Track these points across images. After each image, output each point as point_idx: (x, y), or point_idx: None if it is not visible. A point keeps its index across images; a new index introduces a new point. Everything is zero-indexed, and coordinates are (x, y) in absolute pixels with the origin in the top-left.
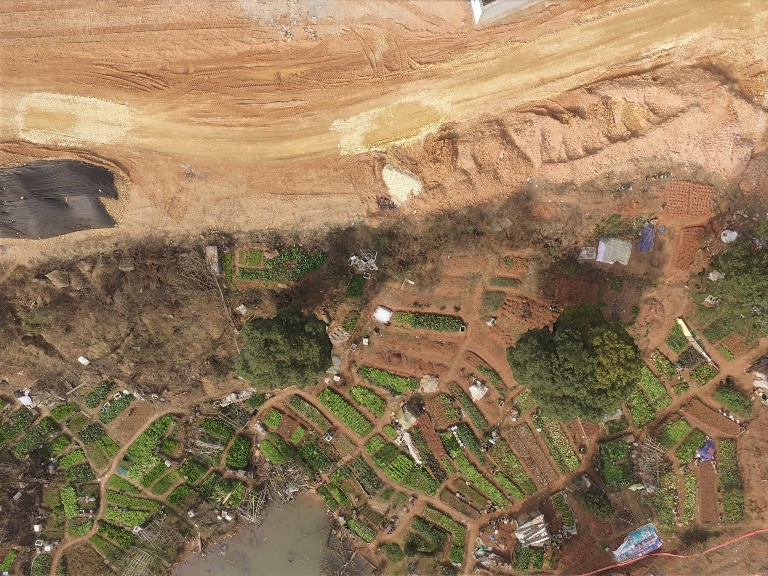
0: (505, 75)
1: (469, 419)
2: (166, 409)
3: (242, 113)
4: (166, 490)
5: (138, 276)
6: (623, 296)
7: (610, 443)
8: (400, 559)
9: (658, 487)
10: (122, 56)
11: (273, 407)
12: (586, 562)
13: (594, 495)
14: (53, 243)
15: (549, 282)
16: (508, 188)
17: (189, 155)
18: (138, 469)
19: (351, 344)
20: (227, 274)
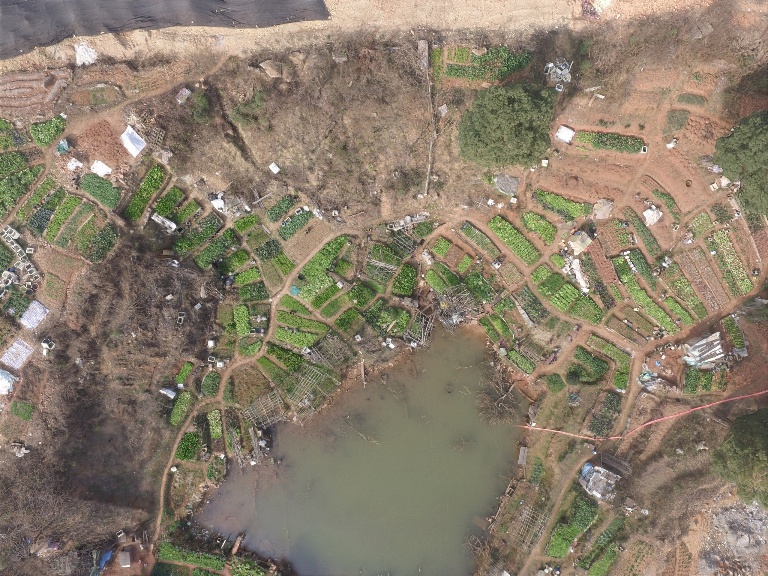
0: None
1: (642, 244)
2: (341, 230)
3: None
4: (335, 313)
5: (348, 69)
6: None
7: None
8: (561, 389)
9: None
10: None
11: (441, 236)
12: (757, 382)
13: None
14: (267, 34)
15: (734, 101)
16: None
17: None
18: (311, 289)
19: None
20: (435, 70)
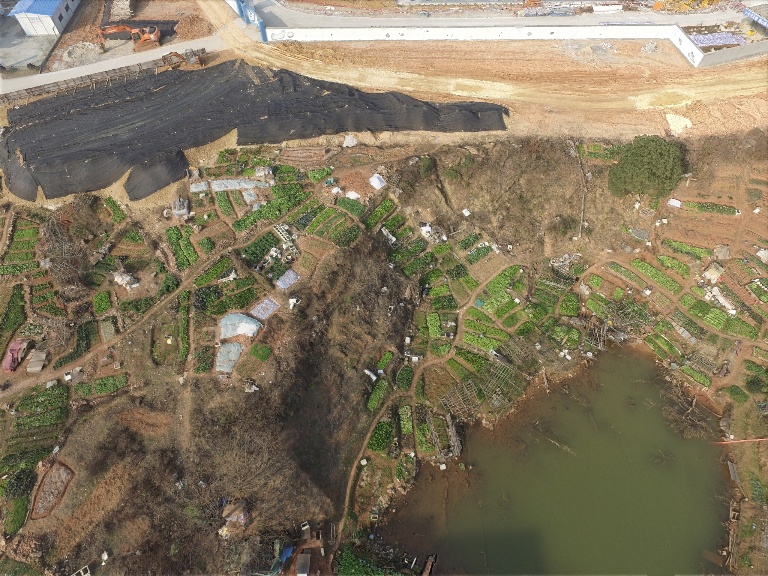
0: (721, 85)
1: (766, 274)
2: (514, 262)
3: (576, 91)
4: (514, 324)
5: None
6: None
7: None
8: (745, 400)
9: None
10: (507, 69)
11: (593, 273)
12: None
13: None
14: (468, 135)
15: None
16: (745, 128)
17: (548, 104)
18: (493, 302)
19: (656, 220)
20: (581, 154)
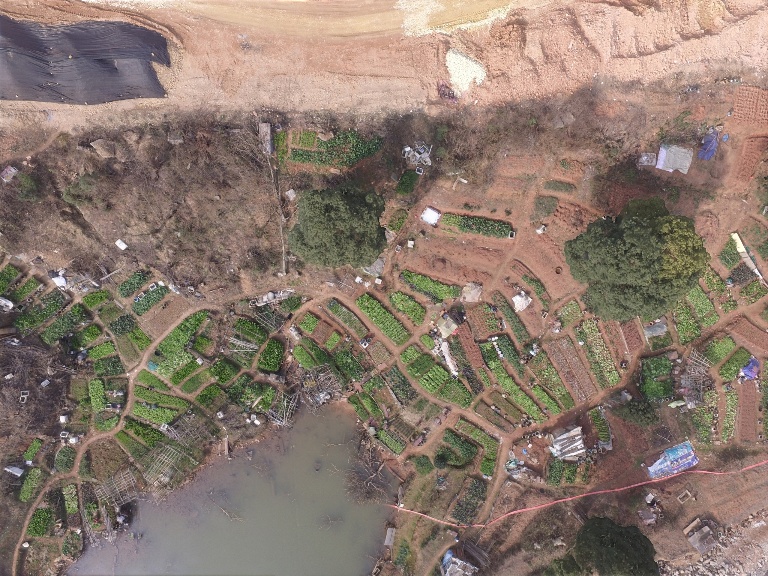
0: None
1: (510, 330)
2: (201, 305)
3: None
4: (196, 389)
5: (186, 151)
6: (679, 207)
7: (653, 359)
8: (429, 471)
9: (701, 401)
10: None
11: (309, 311)
12: (620, 477)
13: (639, 403)
14: (99, 110)
15: (604, 189)
16: (573, 83)
17: (246, 25)
18: (169, 365)
19: (396, 245)
20: (279, 154)
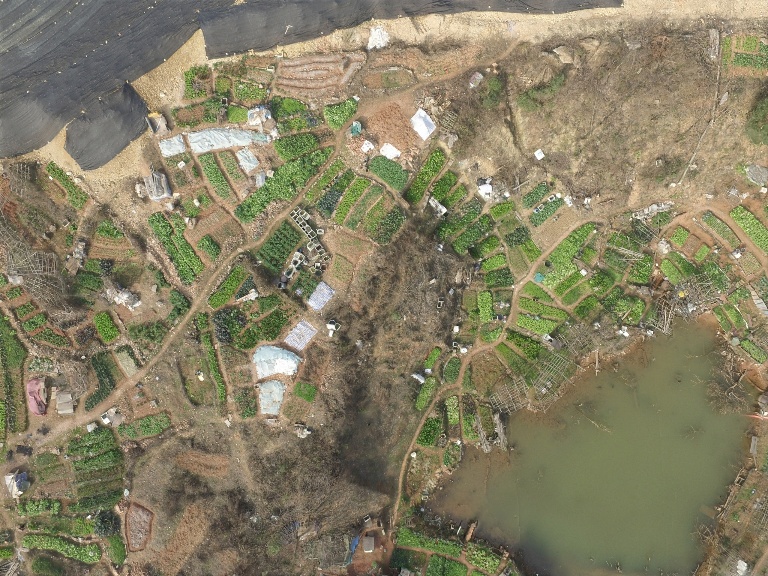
0: None
1: None
2: (587, 218)
3: None
4: (575, 301)
5: None
6: None
7: None
8: None
9: None
10: None
11: (679, 225)
12: None
13: None
14: (560, 20)
15: None
16: None
17: None
18: (556, 276)
19: None
20: (724, 58)
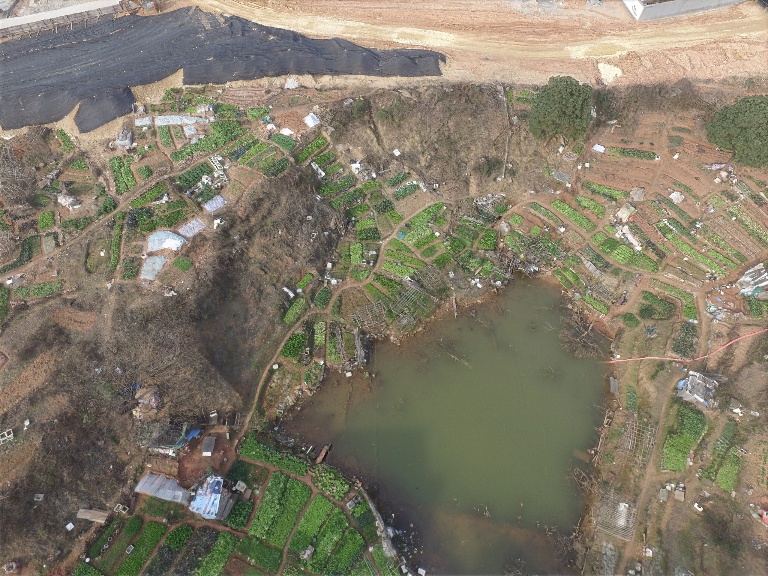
0: (658, 37)
1: (675, 214)
2: (439, 200)
3: (515, 40)
4: (432, 255)
5: None
6: None
7: None
8: (637, 325)
9: None
10: (451, 19)
11: (515, 213)
12: None
13: None
14: (404, 80)
15: None
16: (674, 78)
17: (486, 52)
18: (414, 235)
19: (578, 164)
20: (509, 98)
